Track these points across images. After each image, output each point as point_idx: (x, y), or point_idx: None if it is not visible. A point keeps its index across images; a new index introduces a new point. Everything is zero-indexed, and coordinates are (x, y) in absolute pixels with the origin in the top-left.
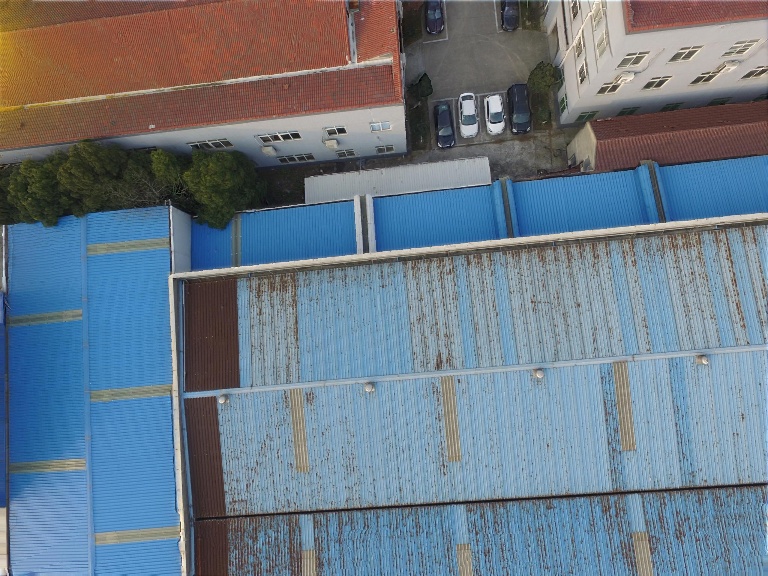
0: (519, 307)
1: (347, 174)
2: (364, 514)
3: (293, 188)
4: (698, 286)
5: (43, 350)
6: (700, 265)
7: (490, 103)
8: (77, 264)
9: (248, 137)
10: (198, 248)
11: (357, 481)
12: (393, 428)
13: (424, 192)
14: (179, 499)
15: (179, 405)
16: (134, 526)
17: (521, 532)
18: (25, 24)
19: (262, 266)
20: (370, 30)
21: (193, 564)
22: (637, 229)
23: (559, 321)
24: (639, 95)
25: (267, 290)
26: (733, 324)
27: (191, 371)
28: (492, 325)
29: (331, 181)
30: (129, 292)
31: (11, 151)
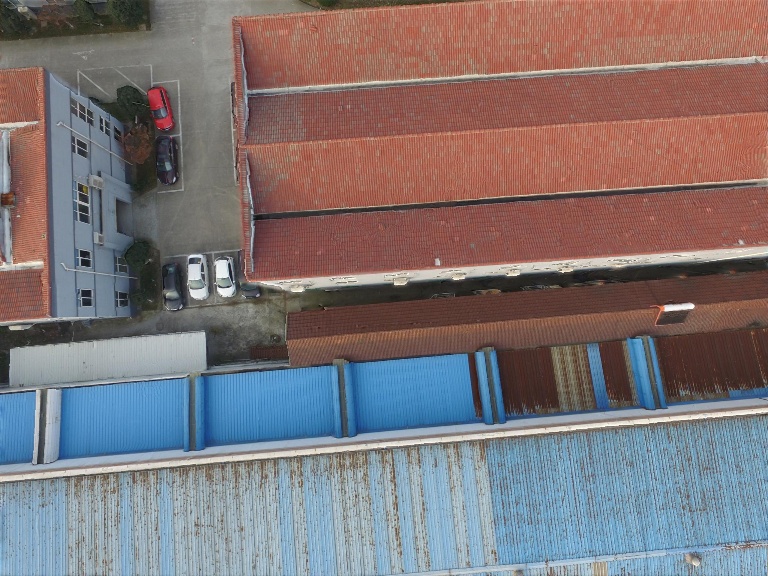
0: (182, 531)
1: (56, 346)
2: None
3: None
4: (361, 510)
5: None
6: (364, 487)
7: (217, 268)
8: None
9: None
10: None
11: None
12: None
13: (116, 383)
14: None
15: None
16: None
17: None
18: None
19: None
20: (25, 230)
21: None
22: (298, 454)
23: (221, 547)
24: (342, 285)
25: None
26: (390, 551)
27: None
28: (153, 550)
29: (38, 353)
30: None
31: None
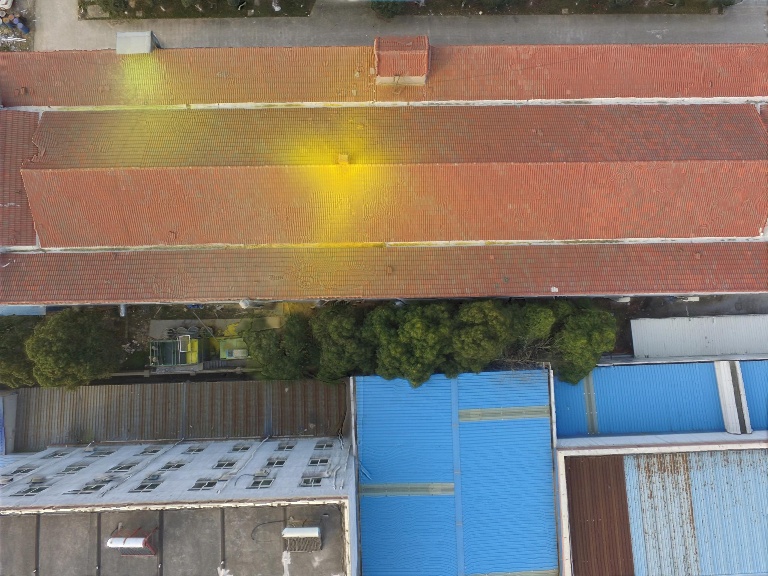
0: None
1: (676, 319)
2: None
3: None
4: None
5: (404, 525)
6: None
7: None
8: (447, 431)
9: None
10: None
11: None
12: None
13: None
14: None
15: None
16: None
17: None
18: (410, 156)
19: (664, 449)
20: None
21: None
22: None
23: None
24: None
25: (657, 470)
26: None
27: (579, 558)
28: None
29: (660, 326)
30: (506, 465)
31: None
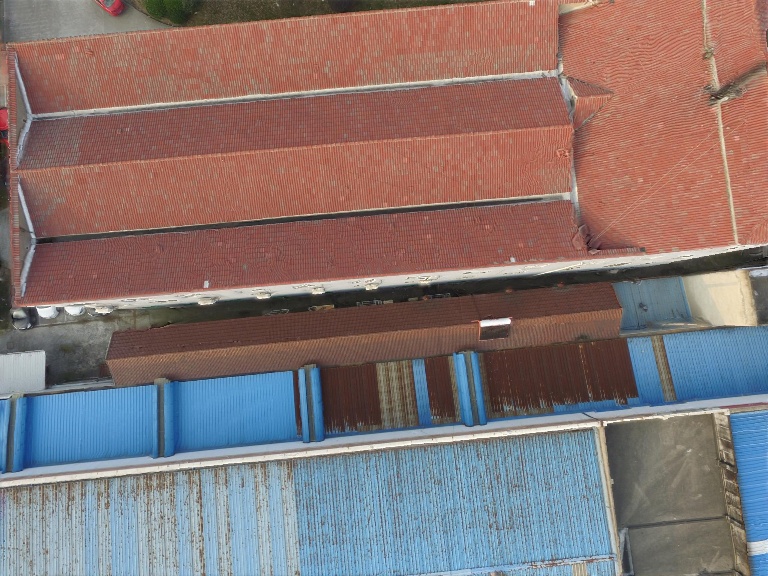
0: None
1: None
2: None
3: None
4: (166, 531)
5: None
6: (170, 508)
7: None
8: None
9: None
10: None
11: None
12: None
13: None
14: None
15: None
16: None
17: None
18: None
19: None
20: None
21: None
22: (99, 476)
23: (25, 569)
24: (169, 303)
25: None
26: (194, 572)
27: None
28: None
29: None
30: None
31: None
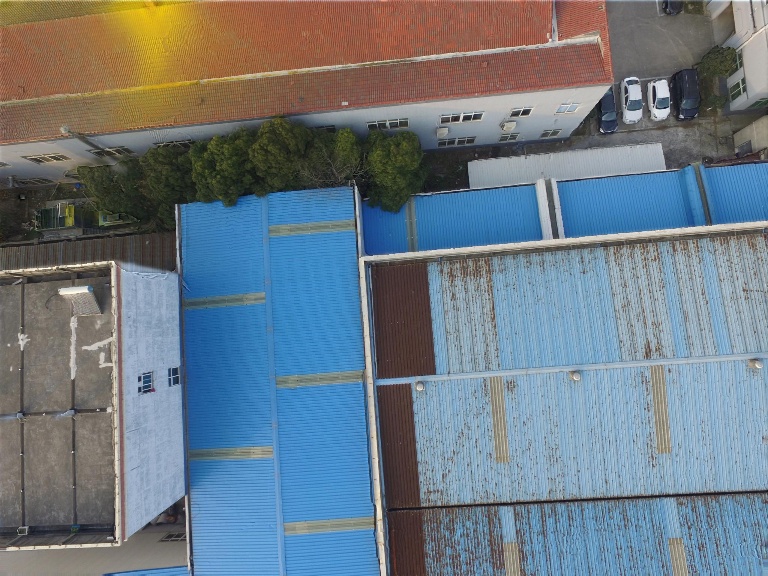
0: (730, 295)
1: (513, 158)
2: (568, 506)
3: (447, 173)
4: None
5: (223, 334)
6: None
7: (657, 88)
8: (258, 245)
9: (431, 117)
10: (371, 231)
11: (560, 472)
12: (599, 418)
13: (608, 177)
14: (376, 489)
15: (373, 392)
16: (324, 516)
17: (736, 526)
18: None
19: (459, 250)
20: (573, 7)
21: (388, 556)
22: None
23: None
24: None
25: (460, 275)
26: None
27: (383, 357)
28: (702, 313)
29: (496, 165)
30: (314, 275)
31: (190, 127)
